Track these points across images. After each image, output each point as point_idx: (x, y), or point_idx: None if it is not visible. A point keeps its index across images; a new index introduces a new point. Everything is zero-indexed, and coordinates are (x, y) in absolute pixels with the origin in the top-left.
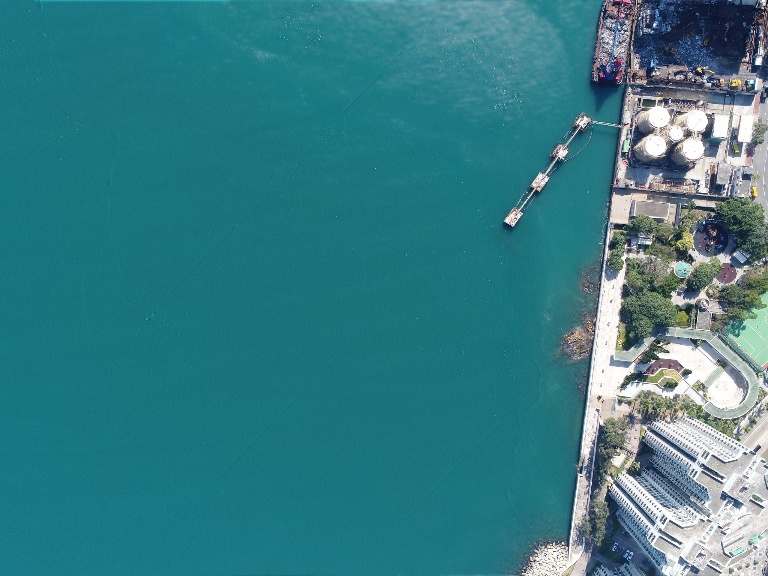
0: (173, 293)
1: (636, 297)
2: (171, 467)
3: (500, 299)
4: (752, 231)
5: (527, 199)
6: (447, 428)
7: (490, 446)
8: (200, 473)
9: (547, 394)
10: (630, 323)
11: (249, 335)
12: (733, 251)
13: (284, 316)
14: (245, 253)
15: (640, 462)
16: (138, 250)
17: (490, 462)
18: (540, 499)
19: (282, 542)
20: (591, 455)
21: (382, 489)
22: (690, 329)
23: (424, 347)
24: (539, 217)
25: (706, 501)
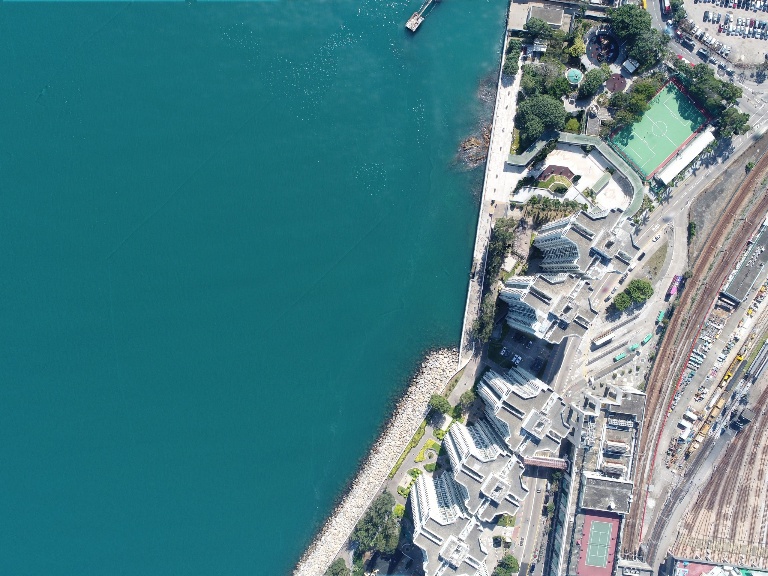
0: (65, 66)
1: (529, 99)
2: (58, 252)
3: (394, 86)
4: (639, 35)
5: (428, 4)
6: (338, 216)
7: (380, 235)
8: (87, 256)
9: (443, 201)
10: (524, 128)
11: (142, 115)
12: (623, 62)
13: (179, 98)
14: (141, 30)
15: (530, 267)
16: (31, 23)
17: (380, 251)
18: (433, 306)
19: (170, 332)
20: (483, 260)
21: (271, 276)
22: (580, 134)
23: (318, 132)
24: (440, 23)
25: (575, 259)
